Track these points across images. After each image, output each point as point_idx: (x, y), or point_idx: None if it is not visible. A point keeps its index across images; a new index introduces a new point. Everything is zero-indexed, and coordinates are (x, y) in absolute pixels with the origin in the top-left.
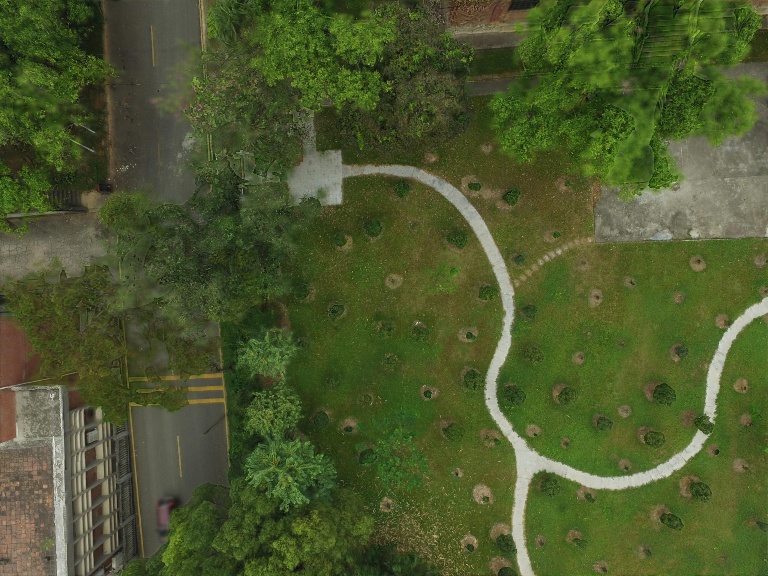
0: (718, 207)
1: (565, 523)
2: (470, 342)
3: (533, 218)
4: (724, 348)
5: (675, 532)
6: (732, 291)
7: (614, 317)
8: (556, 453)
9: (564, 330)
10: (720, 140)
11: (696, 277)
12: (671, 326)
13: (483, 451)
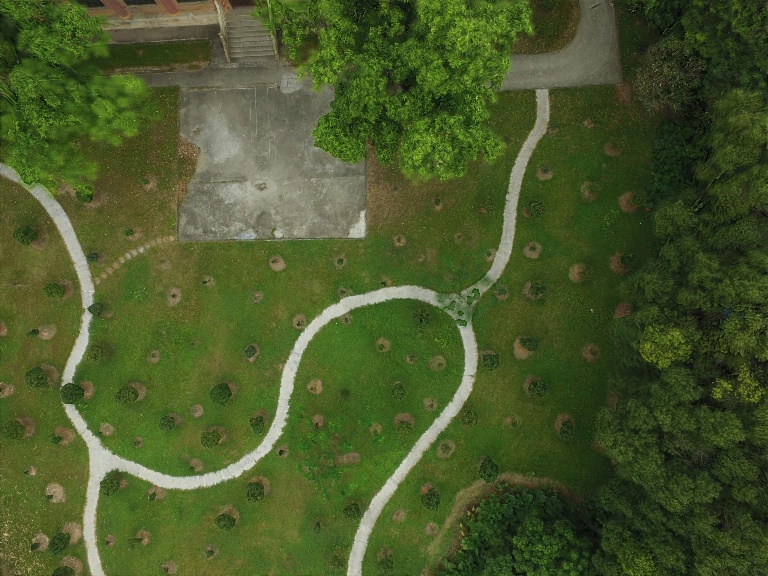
0: (303, 207)
1: (134, 523)
2: (48, 339)
3: (117, 216)
4: (300, 348)
5: (242, 533)
6: (310, 291)
7: (191, 316)
8: (128, 452)
9: (140, 328)
10: (308, 140)
11: (275, 277)
12: (247, 326)
13: (57, 449)
